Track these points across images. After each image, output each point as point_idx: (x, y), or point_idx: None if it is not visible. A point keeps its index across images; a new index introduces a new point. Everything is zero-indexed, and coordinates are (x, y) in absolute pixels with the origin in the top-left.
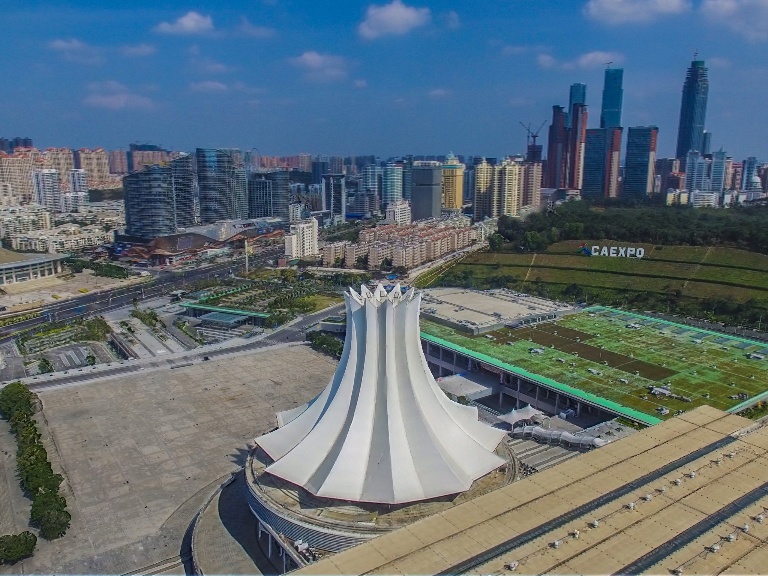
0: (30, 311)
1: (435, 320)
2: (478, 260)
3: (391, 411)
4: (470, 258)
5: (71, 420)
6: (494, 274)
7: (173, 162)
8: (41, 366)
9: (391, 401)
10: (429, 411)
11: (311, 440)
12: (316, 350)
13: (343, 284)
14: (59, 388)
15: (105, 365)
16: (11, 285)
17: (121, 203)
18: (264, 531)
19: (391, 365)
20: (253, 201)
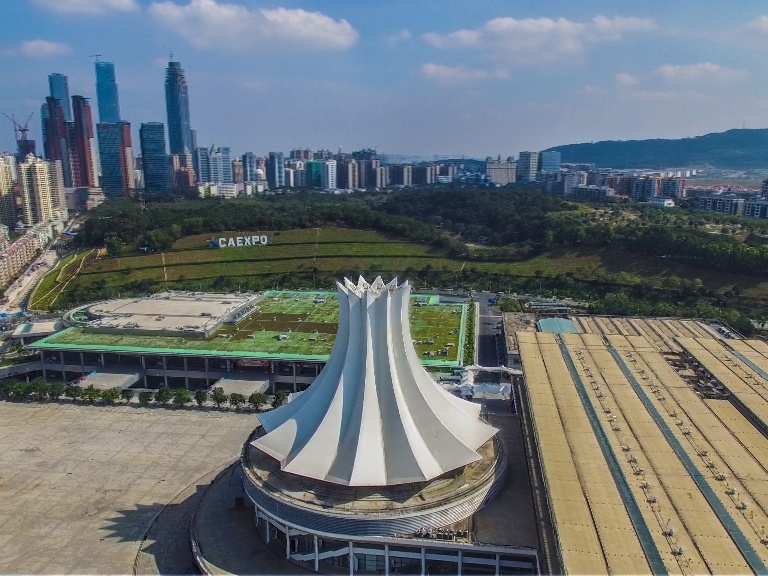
0: None
1: (146, 333)
2: (101, 268)
3: None
4: (90, 267)
5: None
6: (131, 279)
7: None
8: None
9: None
10: None
11: (363, 442)
12: (21, 402)
13: None
14: None
15: None
16: None
17: None
18: (330, 557)
19: None
20: None
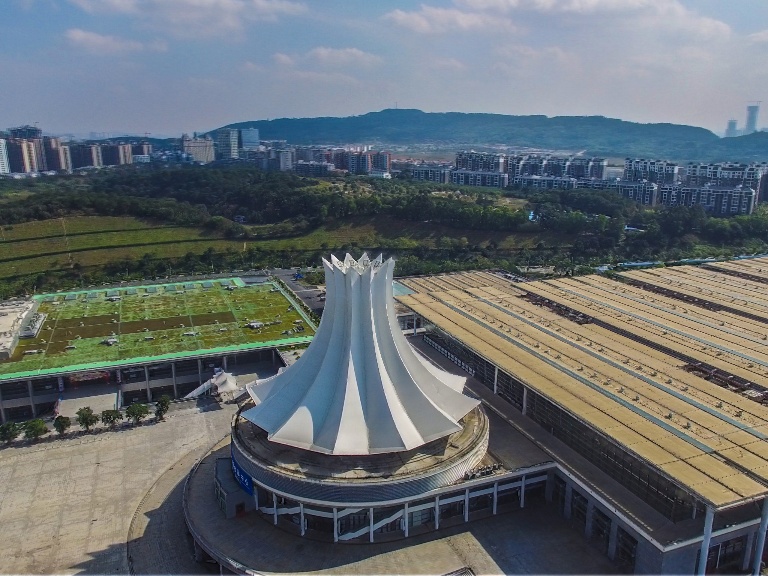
0: None
1: None
2: None
3: None
4: None
5: None
6: None
7: None
8: None
9: None
10: None
11: (393, 410)
12: None
13: None
14: None
15: None
16: None
17: None
18: None
19: None
20: None
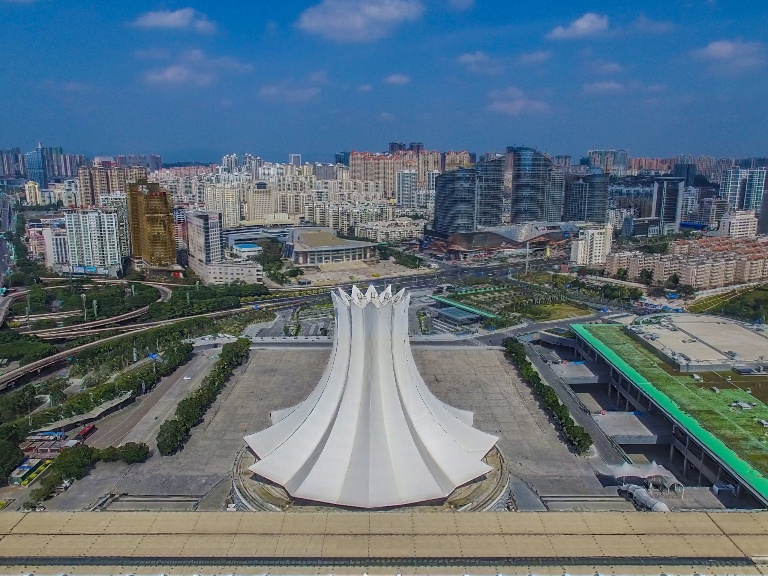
0: (326, 287)
1: (649, 348)
2: None
3: (344, 411)
4: None
5: (260, 374)
6: None
7: (485, 163)
8: (285, 330)
9: (347, 401)
10: (392, 422)
11: (288, 422)
12: (506, 357)
13: (609, 297)
14: (279, 349)
15: (326, 337)
16: (327, 264)
17: (432, 201)
18: None
19: (358, 366)
20: (568, 204)
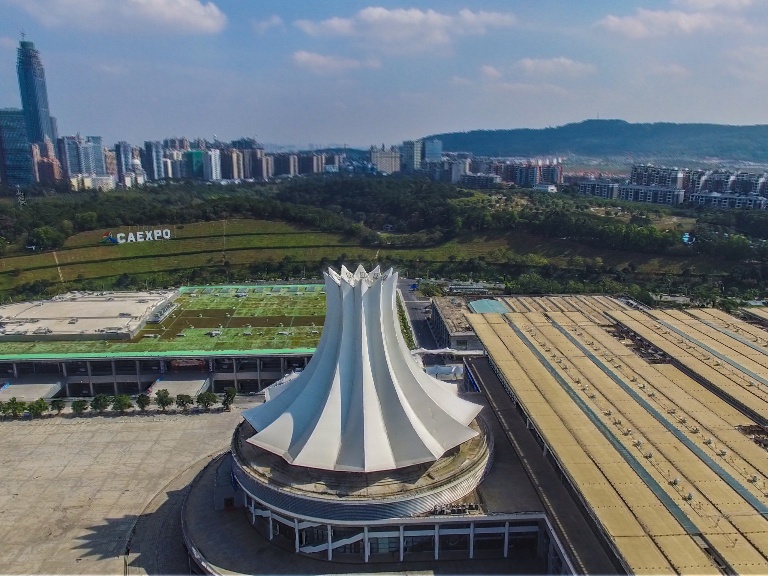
0: None
1: (62, 339)
2: None
3: None
4: None
5: None
6: (22, 282)
7: None
8: None
9: None
10: None
11: (368, 429)
12: None
13: None
14: None
15: None
16: None
17: None
18: None
19: None
20: None
